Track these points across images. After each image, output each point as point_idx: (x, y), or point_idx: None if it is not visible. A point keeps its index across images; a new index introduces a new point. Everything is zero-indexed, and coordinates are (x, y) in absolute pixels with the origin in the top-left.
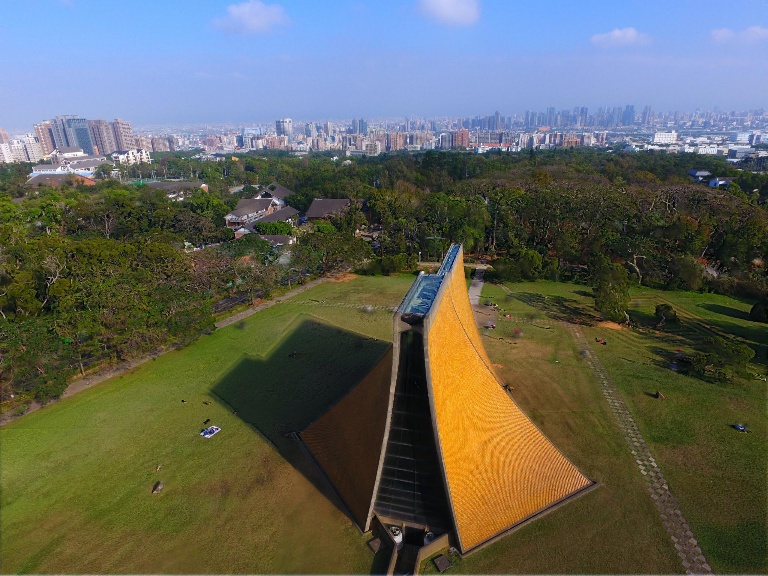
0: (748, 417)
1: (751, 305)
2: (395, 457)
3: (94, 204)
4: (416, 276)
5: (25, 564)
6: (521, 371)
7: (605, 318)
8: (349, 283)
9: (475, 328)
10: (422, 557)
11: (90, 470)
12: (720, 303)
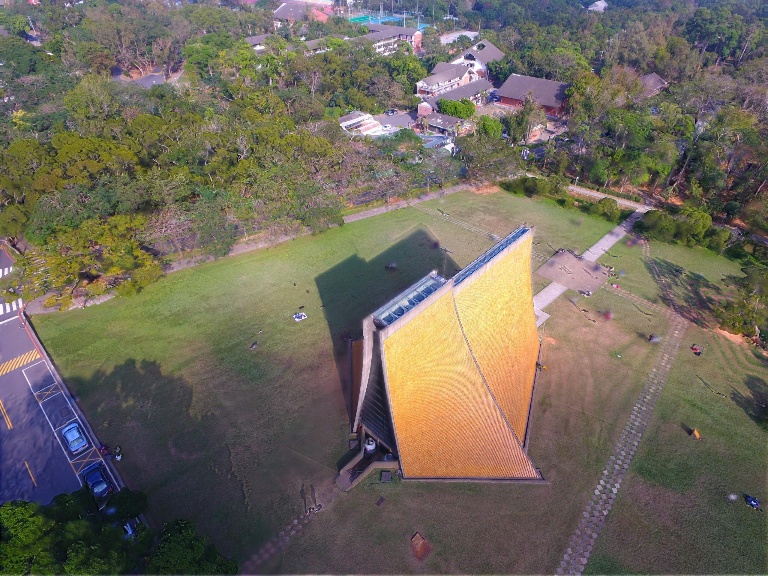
0: None
1: None
2: (373, 400)
3: (307, 58)
4: (559, 205)
5: (176, 366)
6: (569, 354)
7: (720, 327)
8: (485, 198)
9: (521, 308)
10: (375, 467)
11: (225, 318)
12: None
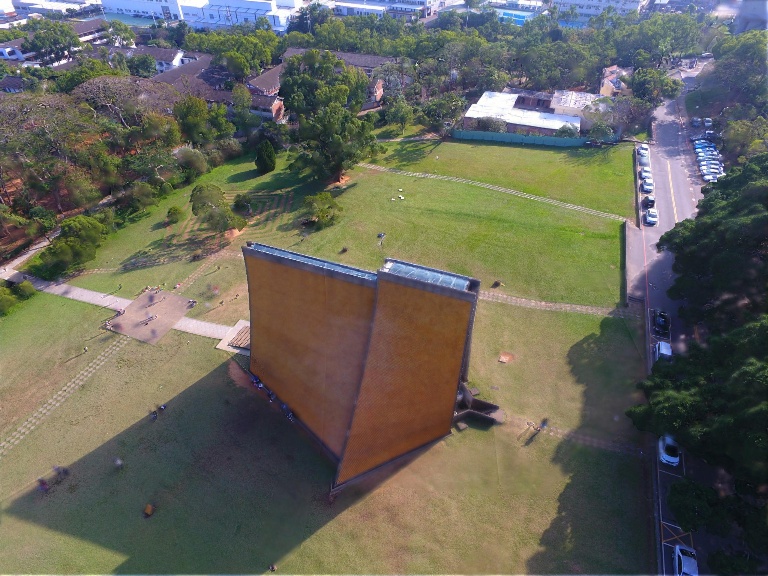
0: (371, 228)
1: (242, 164)
2: None
3: None
4: None
5: None
6: None
7: (239, 230)
8: None
9: None
10: None
11: None
12: (231, 173)
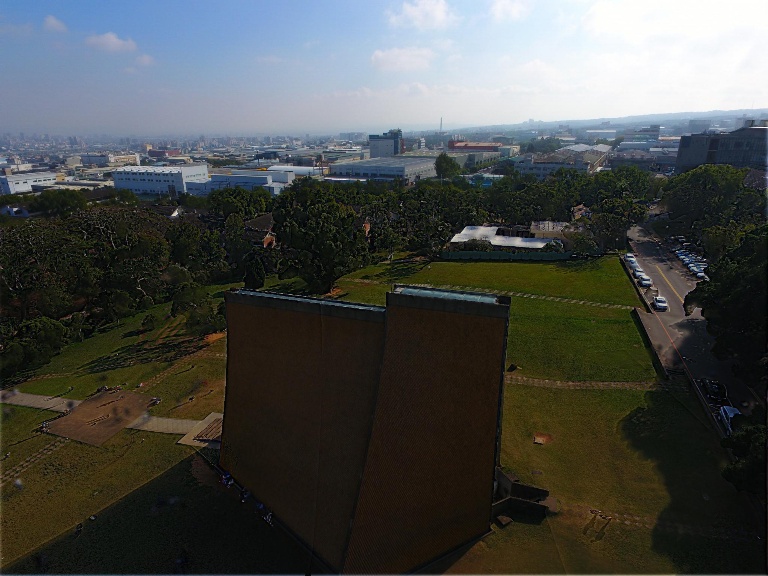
0: None
1: (230, 284)
2: None
3: None
4: None
5: None
6: None
7: (221, 330)
8: None
9: None
10: None
11: None
12: (217, 291)
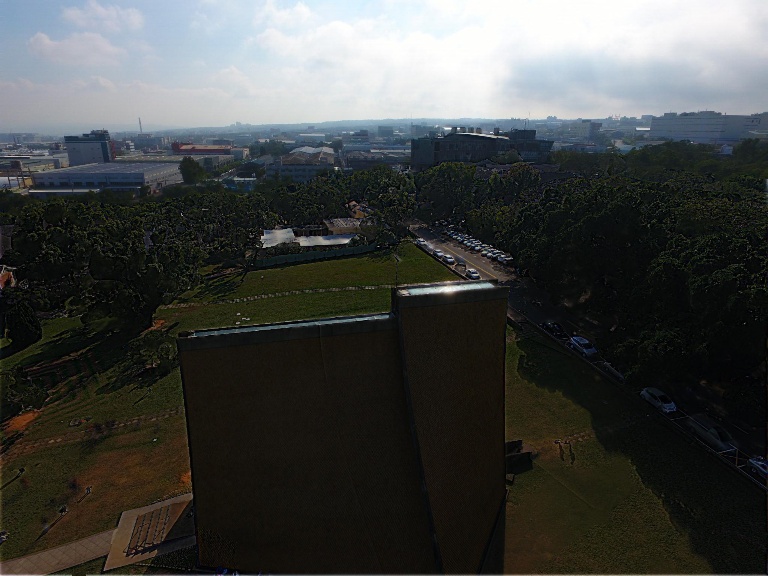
0: None
1: None
2: None
3: None
4: None
5: None
6: None
7: (39, 407)
8: None
9: None
10: None
11: None
12: None
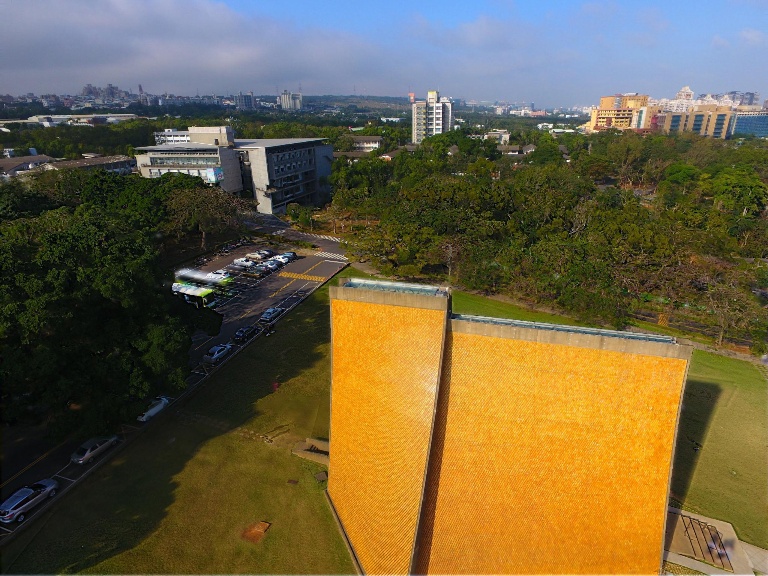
0: None
1: None
2: None
3: None
4: None
5: None
6: None
7: None
8: None
9: (615, 466)
10: None
11: None
12: None
